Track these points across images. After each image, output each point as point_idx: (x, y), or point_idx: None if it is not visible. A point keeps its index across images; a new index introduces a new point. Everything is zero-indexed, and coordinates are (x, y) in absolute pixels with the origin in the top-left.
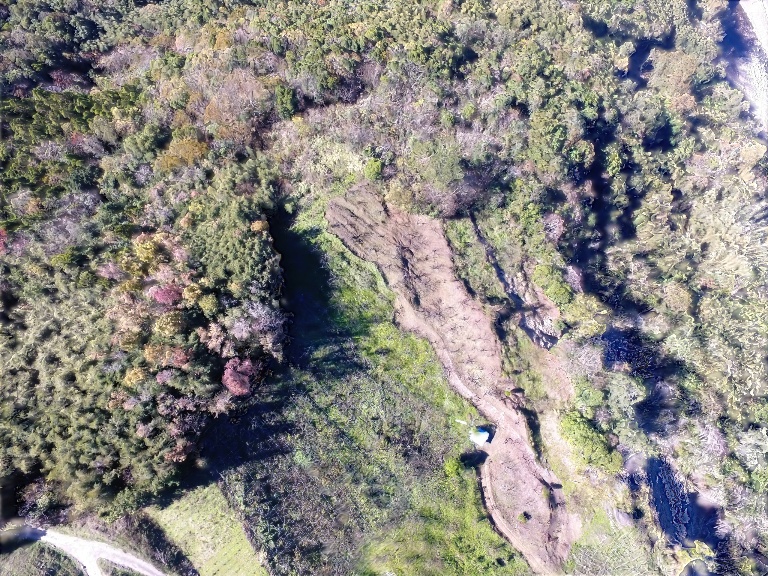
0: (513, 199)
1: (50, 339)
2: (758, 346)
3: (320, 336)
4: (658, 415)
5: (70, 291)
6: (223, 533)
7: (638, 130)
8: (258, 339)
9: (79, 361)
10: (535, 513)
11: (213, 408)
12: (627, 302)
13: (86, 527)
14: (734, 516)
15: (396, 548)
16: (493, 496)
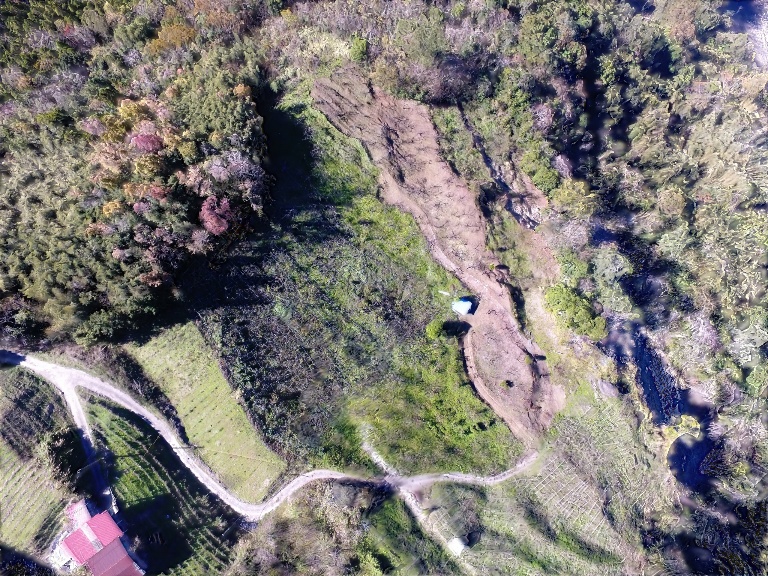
0: (501, 89)
1: (33, 185)
2: (755, 255)
3: (302, 202)
4: (648, 305)
5: (55, 147)
6: (200, 370)
7: (634, 47)
8: (237, 185)
9: (60, 201)
10: (518, 381)
11: (190, 245)
12: (620, 207)
13: (64, 355)
14: (728, 418)
15: (376, 408)
16: (475, 365)
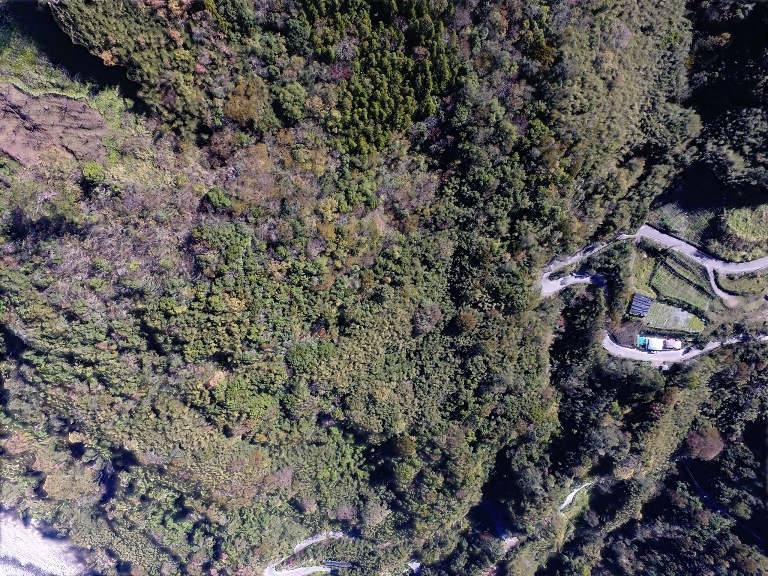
0: None
1: None
2: None
3: (15, 5)
4: None
5: None
6: None
7: None
8: None
9: None
10: None
11: None
12: None
13: None
14: None
15: None
16: None
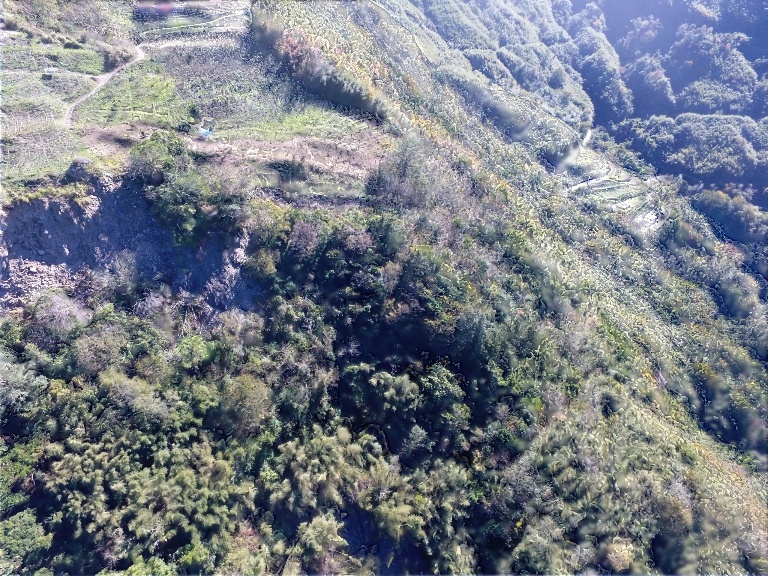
0: None
1: None
2: None
3: None
4: None
5: None
6: None
7: (506, 480)
8: None
9: None
10: None
11: None
12: None
13: None
14: None
15: None
16: None
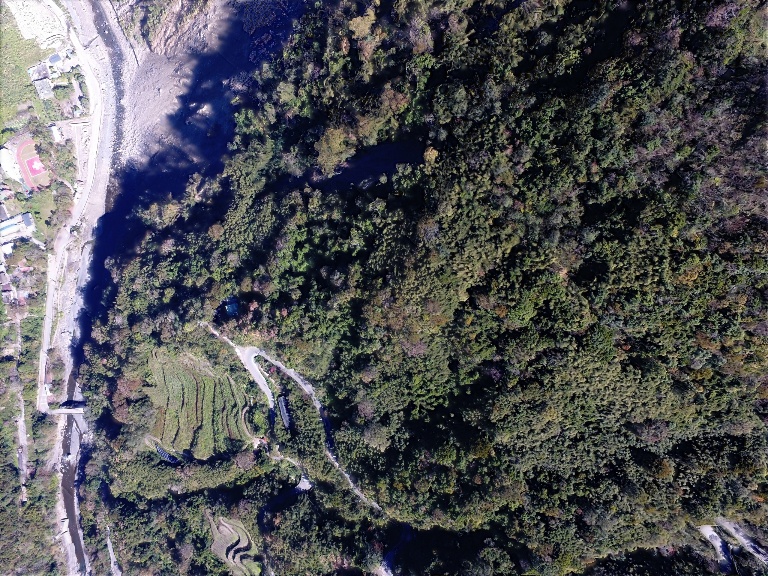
0: None
1: None
2: None
3: None
4: None
5: None
6: None
7: None
8: None
9: None
10: None
11: None
12: None
13: None
14: None
15: None
16: None
